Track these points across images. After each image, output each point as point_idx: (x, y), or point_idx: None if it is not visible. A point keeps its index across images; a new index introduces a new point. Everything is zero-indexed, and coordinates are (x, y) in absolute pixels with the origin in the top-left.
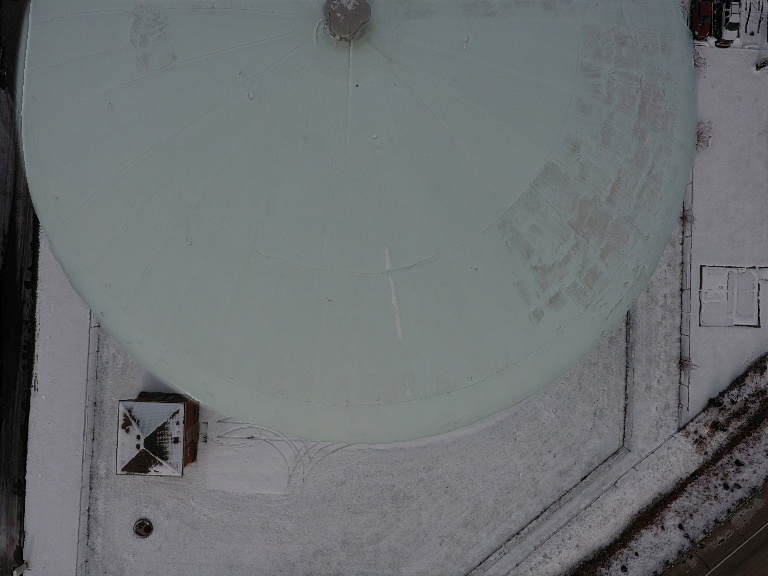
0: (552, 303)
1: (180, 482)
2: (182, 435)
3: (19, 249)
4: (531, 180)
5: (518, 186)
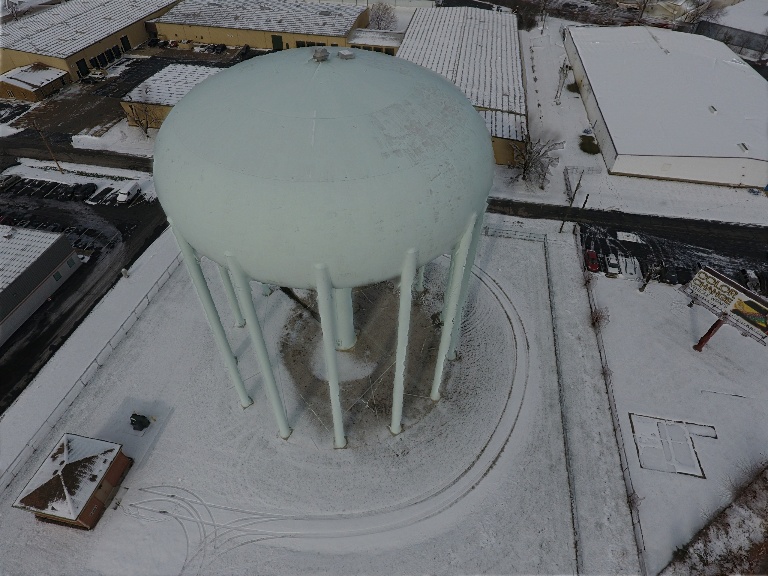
0: (395, 153)
1: (62, 552)
2: (102, 475)
3: (65, 324)
4: (386, 107)
5: (380, 107)
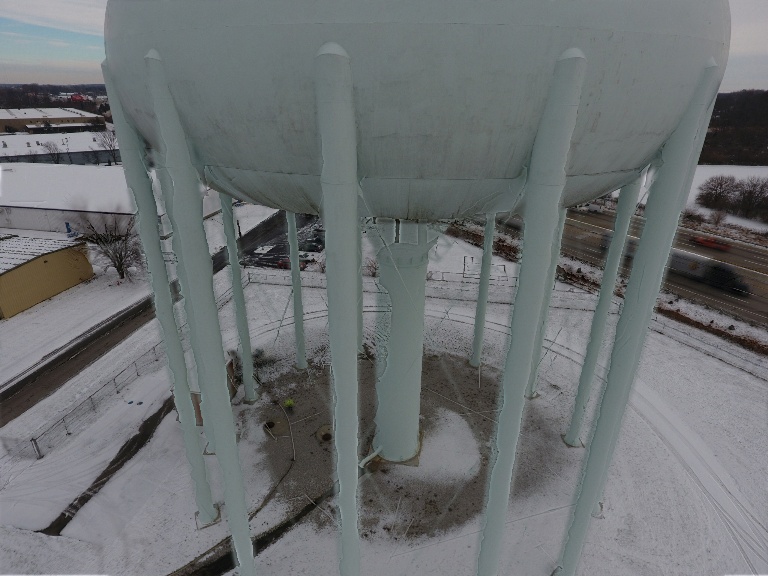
0: None
1: None
2: None
3: None
4: None
5: None
